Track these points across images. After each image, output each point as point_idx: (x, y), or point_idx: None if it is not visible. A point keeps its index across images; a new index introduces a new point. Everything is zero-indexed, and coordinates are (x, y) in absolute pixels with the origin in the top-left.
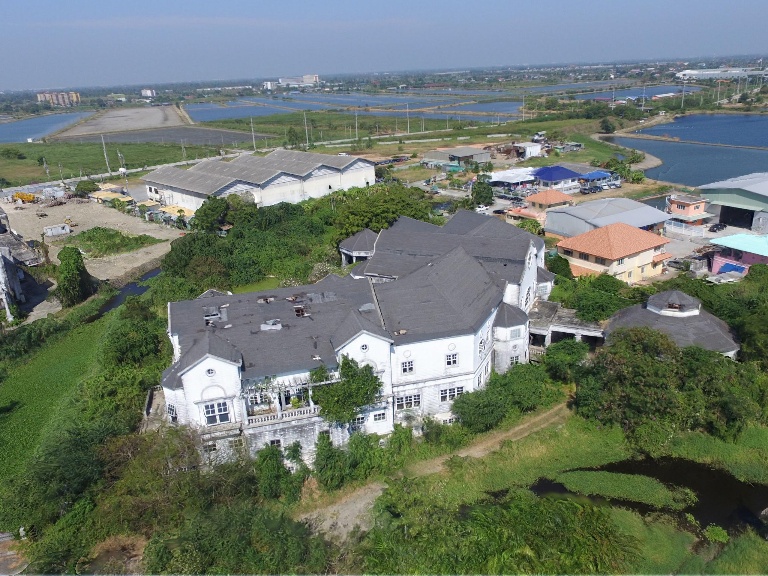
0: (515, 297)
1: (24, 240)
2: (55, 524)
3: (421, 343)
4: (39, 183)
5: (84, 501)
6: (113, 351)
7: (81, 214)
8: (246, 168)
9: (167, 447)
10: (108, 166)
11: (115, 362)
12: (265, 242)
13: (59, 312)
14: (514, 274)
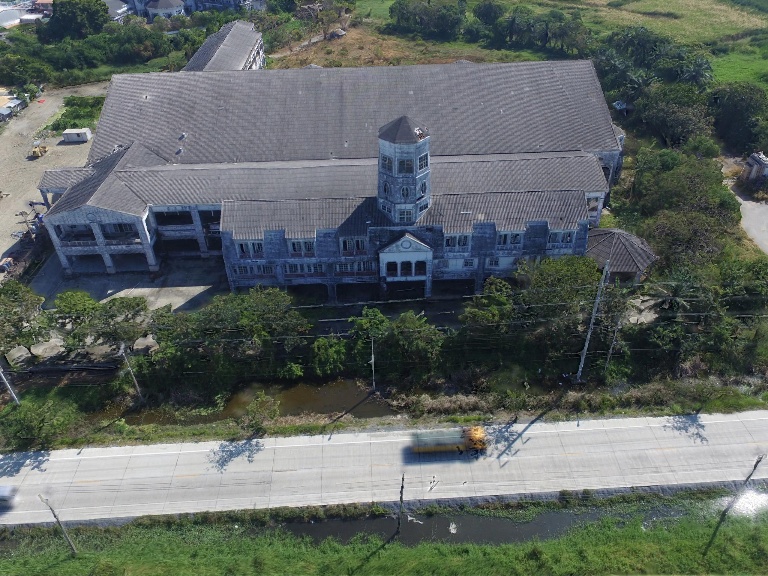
0: None
1: None
2: None
3: None
4: None
5: None
6: None
7: None
8: None
9: None
10: None
11: None
12: None
13: None
14: None
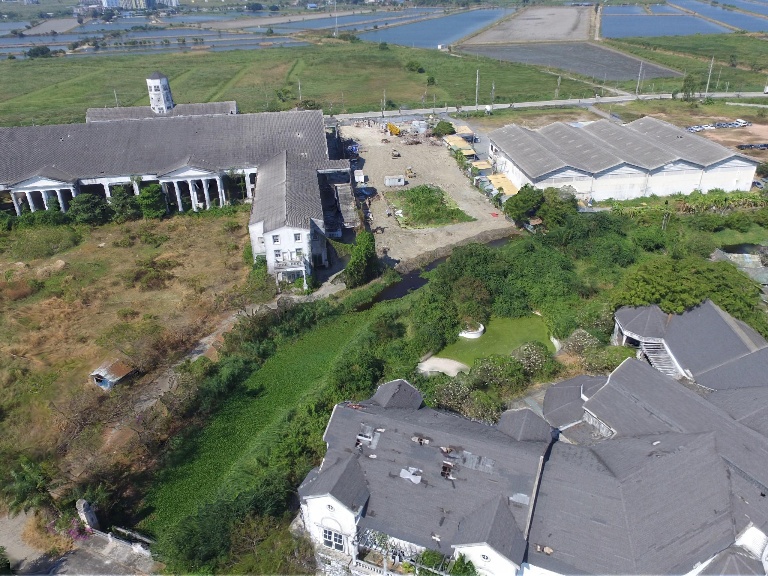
0: (758, 545)
1: (367, 185)
2: (188, 573)
3: (563, 575)
4: (417, 109)
5: (208, 569)
6: (335, 378)
7: (426, 161)
8: (590, 145)
9: (295, 540)
10: (477, 101)
11: (335, 387)
12: (548, 269)
13: (341, 293)
14: (767, 517)
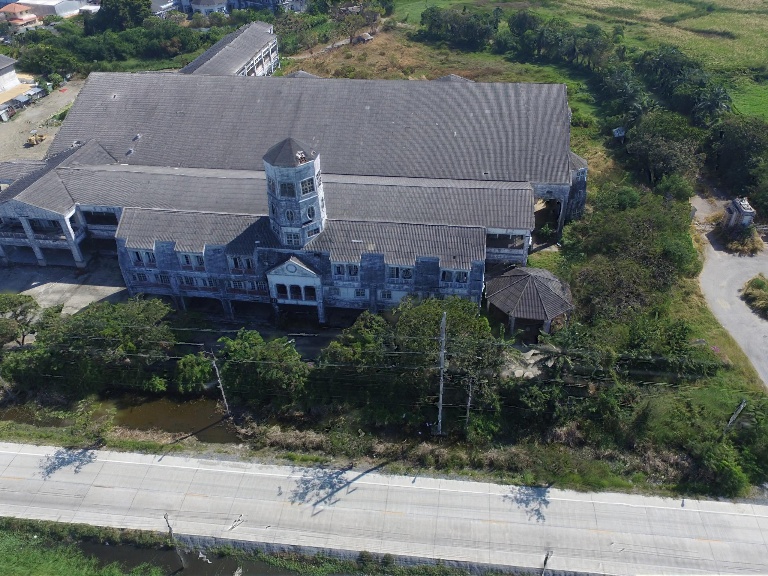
0: None
1: None
2: None
3: None
4: None
5: None
6: None
7: None
8: None
9: None
10: None
11: None
12: None
13: None
14: None
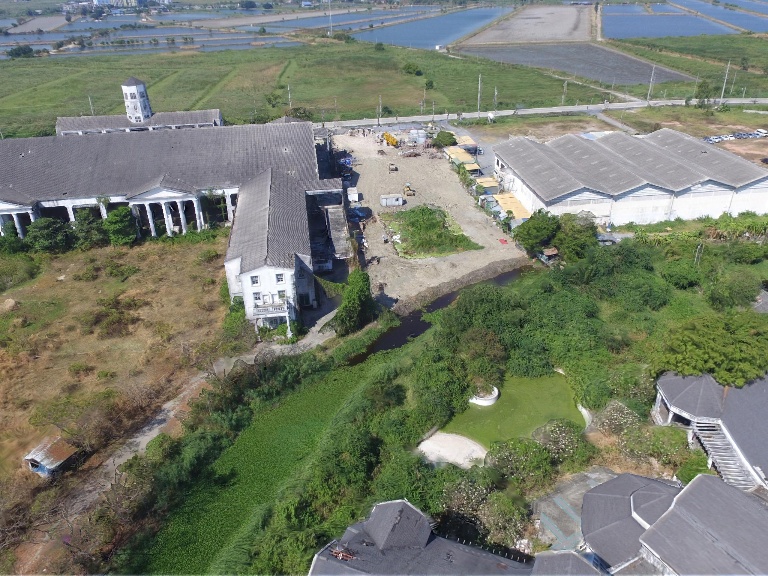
0: None
1: (362, 205)
2: None
3: None
4: (415, 116)
5: None
6: (320, 470)
7: (425, 176)
8: (608, 162)
9: None
10: (479, 108)
11: (320, 480)
12: (571, 317)
13: (330, 342)
14: None
